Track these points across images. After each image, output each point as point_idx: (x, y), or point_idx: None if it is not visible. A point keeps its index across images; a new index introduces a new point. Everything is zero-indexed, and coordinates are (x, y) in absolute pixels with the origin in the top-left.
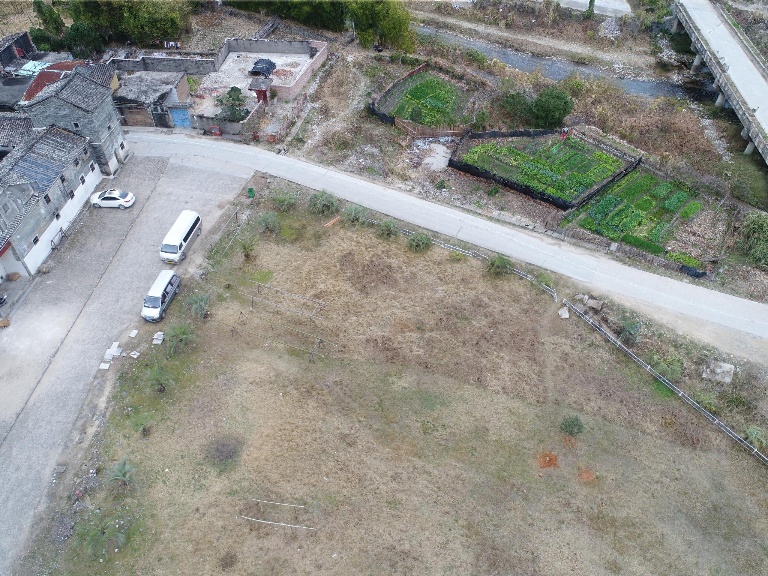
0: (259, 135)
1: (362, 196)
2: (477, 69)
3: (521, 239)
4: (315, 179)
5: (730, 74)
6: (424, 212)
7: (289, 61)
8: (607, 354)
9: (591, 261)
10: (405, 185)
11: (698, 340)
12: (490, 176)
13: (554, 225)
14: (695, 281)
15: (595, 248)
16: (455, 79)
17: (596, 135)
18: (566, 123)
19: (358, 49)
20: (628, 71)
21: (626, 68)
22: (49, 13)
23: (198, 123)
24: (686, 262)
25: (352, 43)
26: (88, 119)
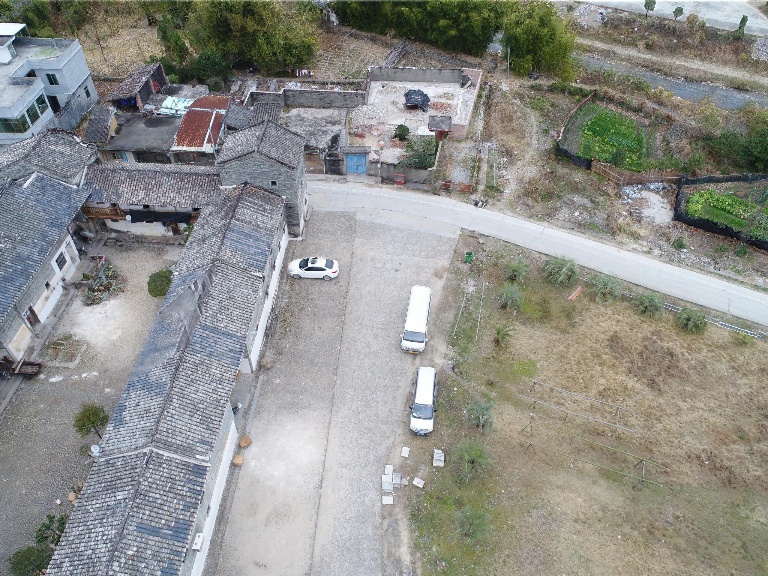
0: (452, 184)
1: (598, 260)
2: None
3: None
4: (534, 239)
5: None
6: (678, 280)
7: (441, 92)
8: None
9: None
10: (639, 245)
11: None
12: (732, 233)
13: None
14: None
15: None
16: (630, 111)
17: None
18: None
19: (509, 77)
20: None
21: None
22: (175, 40)
23: (376, 170)
24: None
25: (497, 69)
26: (290, 176)
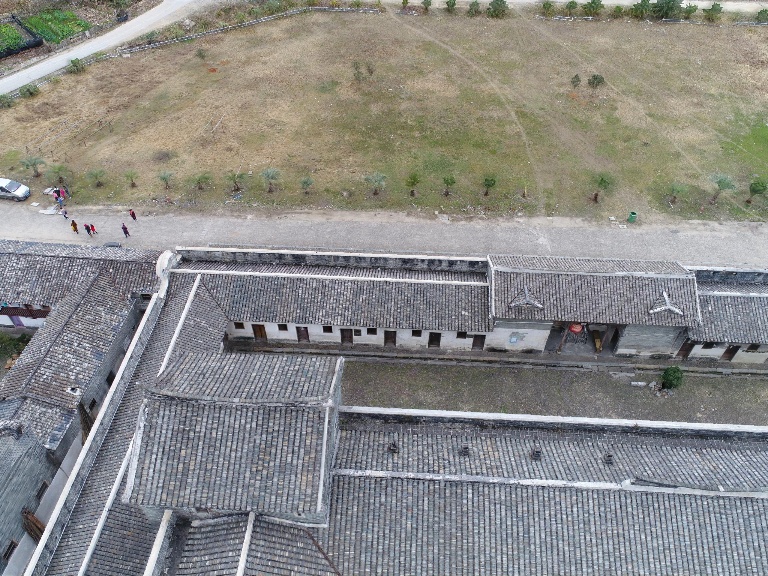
0: None
1: None
2: None
3: (56, 60)
4: None
5: None
6: None
7: None
8: (161, 50)
9: (93, 43)
10: None
11: (168, 24)
12: None
13: (55, 45)
14: (129, 20)
15: (83, 41)
16: None
17: None
18: None
19: None
20: None
21: None
22: None
23: None
24: None
25: None
26: None
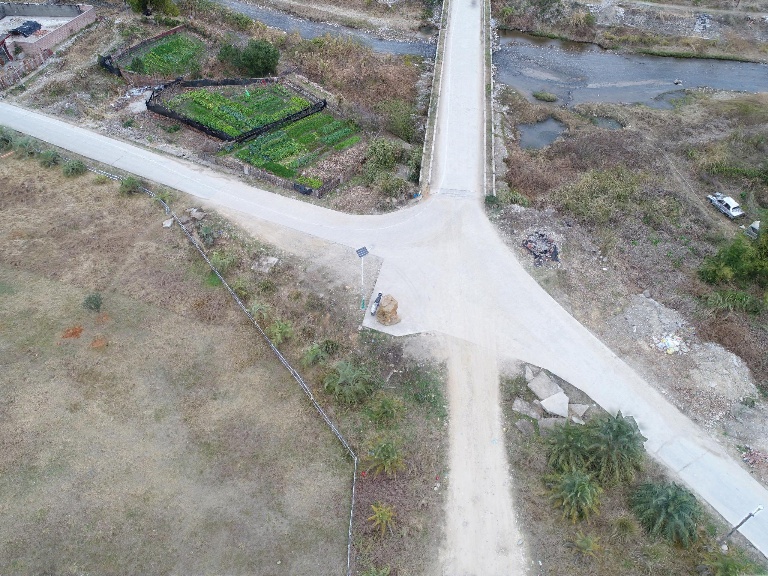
0: None
1: (48, 133)
2: (237, 30)
3: (170, 166)
4: (14, 119)
5: (451, 30)
6: (96, 145)
7: (57, 23)
8: (184, 254)
9: (221, 183)
10: (94, 124)
11: (264, 241)
12: (176, 116)
13: (202, 153)
14: (302, 197)
15: (232, 172)
16: (206, 38)
17: (300, 83)
18: (279, 73)
19: (130, 13)
20: (390, 33)
21: (390, 31)
22: None
23: None
24: (310, 184)
25: None
26: None
